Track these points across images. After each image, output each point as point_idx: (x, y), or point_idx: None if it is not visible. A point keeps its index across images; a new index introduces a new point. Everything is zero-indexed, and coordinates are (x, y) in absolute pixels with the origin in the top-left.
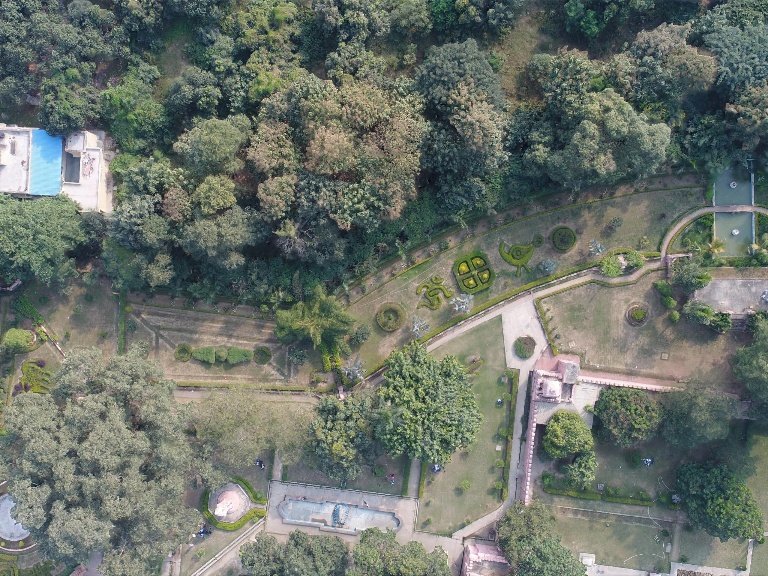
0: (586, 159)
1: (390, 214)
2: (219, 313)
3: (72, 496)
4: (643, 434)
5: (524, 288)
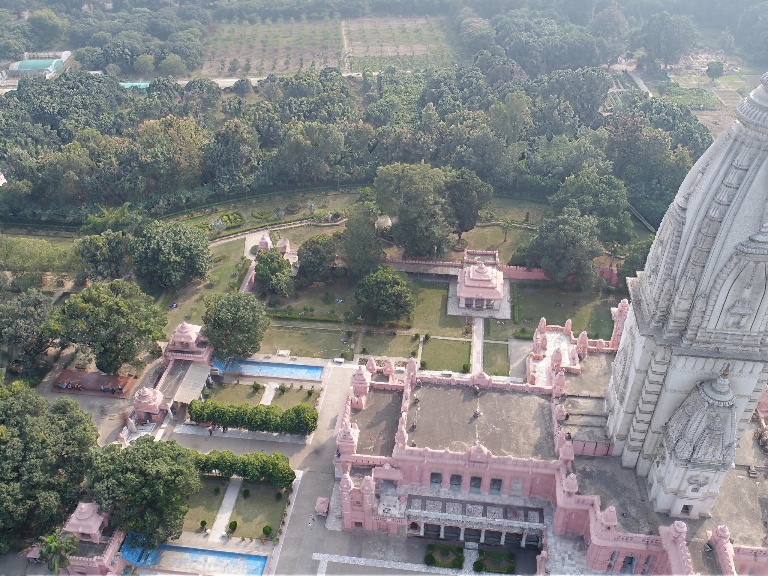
0: (293, 137)
1: (176, 158)
2: (50, 236)
3: None
4: (321, 246)
5: (263, 225)
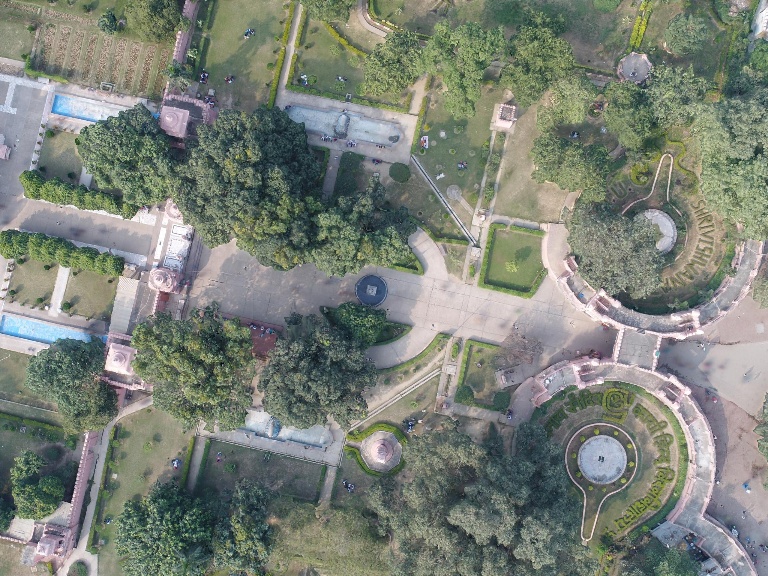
0: None
1: None
2: None
3: (489, 551)
4: None
5: None
